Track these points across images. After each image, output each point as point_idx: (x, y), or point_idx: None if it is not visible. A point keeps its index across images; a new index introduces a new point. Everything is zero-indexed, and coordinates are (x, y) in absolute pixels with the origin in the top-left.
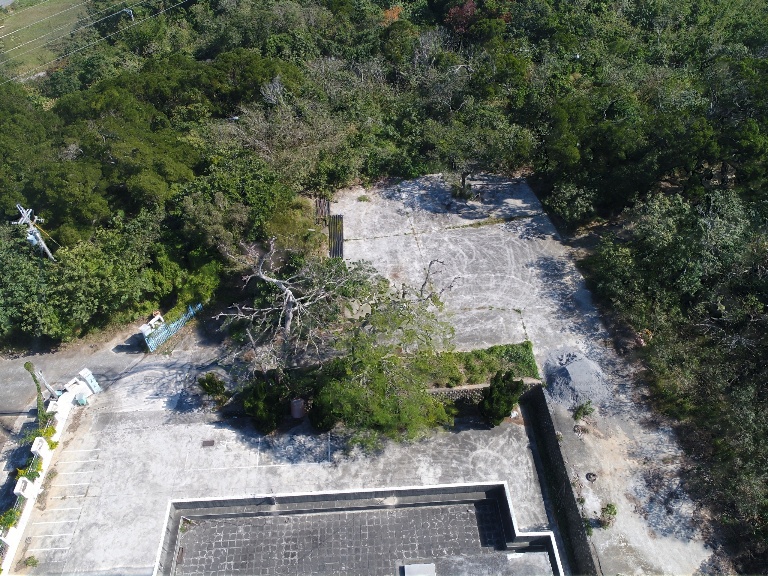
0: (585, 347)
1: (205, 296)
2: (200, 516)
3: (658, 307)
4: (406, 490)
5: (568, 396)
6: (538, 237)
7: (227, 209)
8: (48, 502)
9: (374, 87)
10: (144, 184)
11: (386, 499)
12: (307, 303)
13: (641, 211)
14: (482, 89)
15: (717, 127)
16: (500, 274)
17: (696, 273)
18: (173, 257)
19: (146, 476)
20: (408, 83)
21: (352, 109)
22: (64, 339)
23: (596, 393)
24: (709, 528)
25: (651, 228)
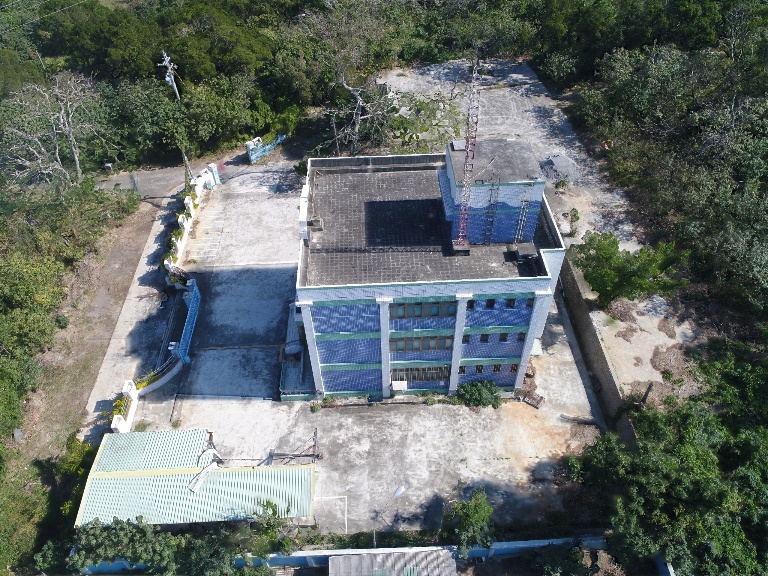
0: (566, 153)
1: (290, 126)
2: (326, 170)
3: (617, 119)
4: None
5: (552, 176)
6: (534, 95)
7: (305, 67)
8: (197, 235)
9: (407, 0)
10: (241, 53)
11: (436, 163)
12: (369, 115)
13: (608, 61)
14: (493, 3)
15: (671, 15)
16: (505, 116)
17: (644, 96)
18: (266, 100)
19: (261, 223)
20: (433, 4)
21: (391, 14)
22: (190, 153)
23: (572, 173)
24: (642, 236)
25: (615, 73)
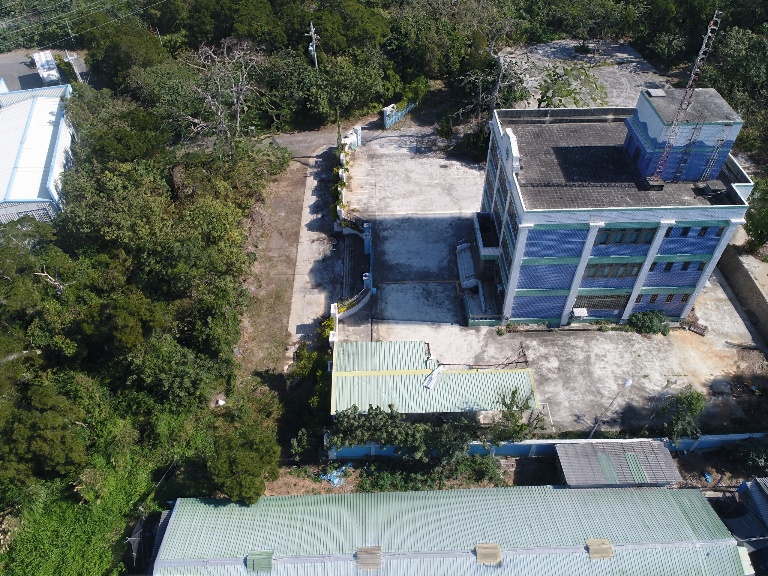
0: None
1: (421, 95)
2: (508, 121)
3: (736, 91)
4: (620, 109)
5: None
6: (643, 72)
7: None
8: (353, 188)
9: None
10: (369, 28)
11: (607, 116)
12: (506, 83)
13: (723, 38)
14: None
15: None
16: (620, 90)
17: (762, 70)
18: (397, 71)
19: (410, 179)
20: None
21: None
22: (329, 118)
23: None
24: None
25: (729, 50)
